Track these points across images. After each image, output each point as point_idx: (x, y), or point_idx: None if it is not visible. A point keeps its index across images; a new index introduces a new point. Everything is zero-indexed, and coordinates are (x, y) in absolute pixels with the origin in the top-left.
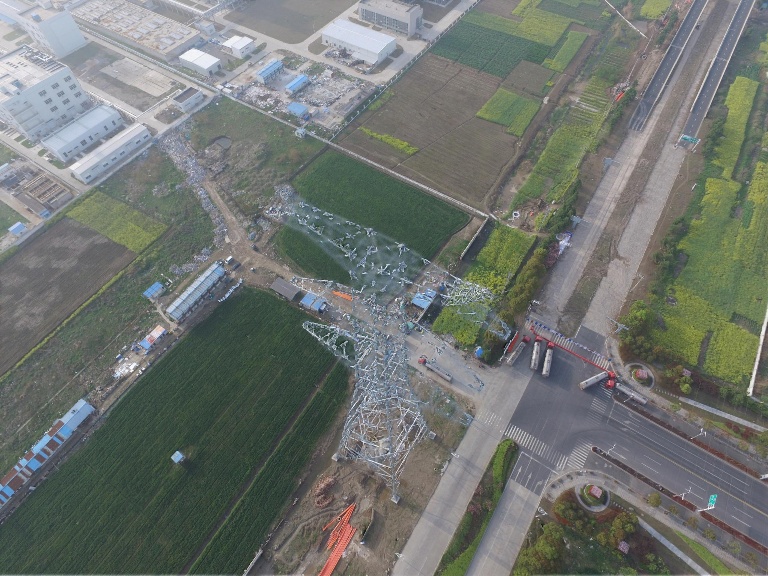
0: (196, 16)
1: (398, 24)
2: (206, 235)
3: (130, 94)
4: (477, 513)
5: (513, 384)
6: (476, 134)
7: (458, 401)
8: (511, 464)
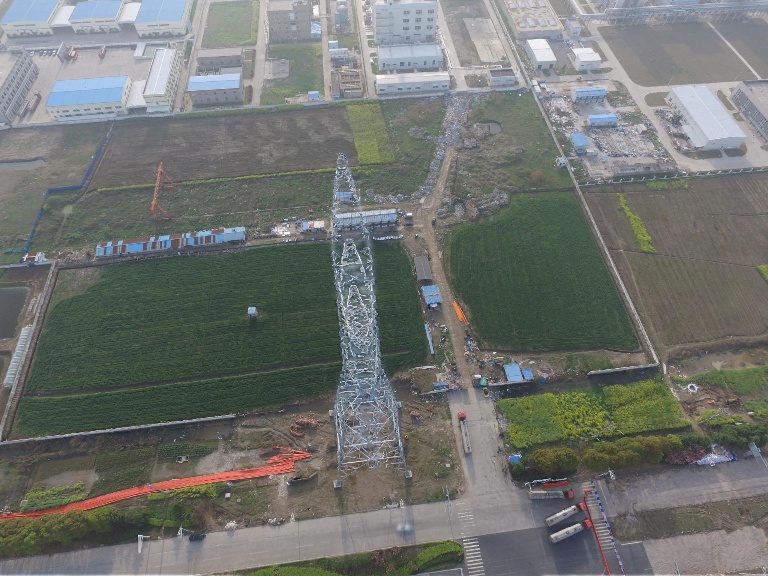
0: (575, 14)
1: (766, 125)
2: (412, 186)
3: (466, 48)
4: (375, 562)
5: (515, 514)
6: (736, 283)
7: (456, 474)
8: (442, 565)
